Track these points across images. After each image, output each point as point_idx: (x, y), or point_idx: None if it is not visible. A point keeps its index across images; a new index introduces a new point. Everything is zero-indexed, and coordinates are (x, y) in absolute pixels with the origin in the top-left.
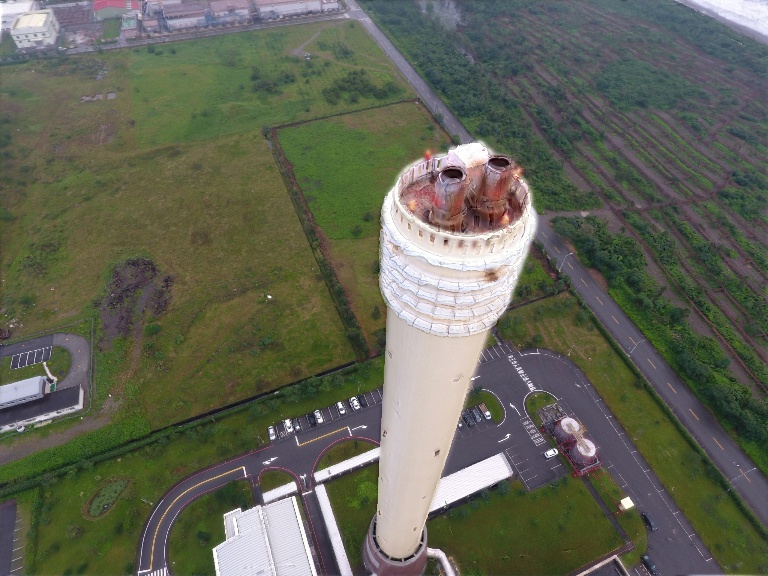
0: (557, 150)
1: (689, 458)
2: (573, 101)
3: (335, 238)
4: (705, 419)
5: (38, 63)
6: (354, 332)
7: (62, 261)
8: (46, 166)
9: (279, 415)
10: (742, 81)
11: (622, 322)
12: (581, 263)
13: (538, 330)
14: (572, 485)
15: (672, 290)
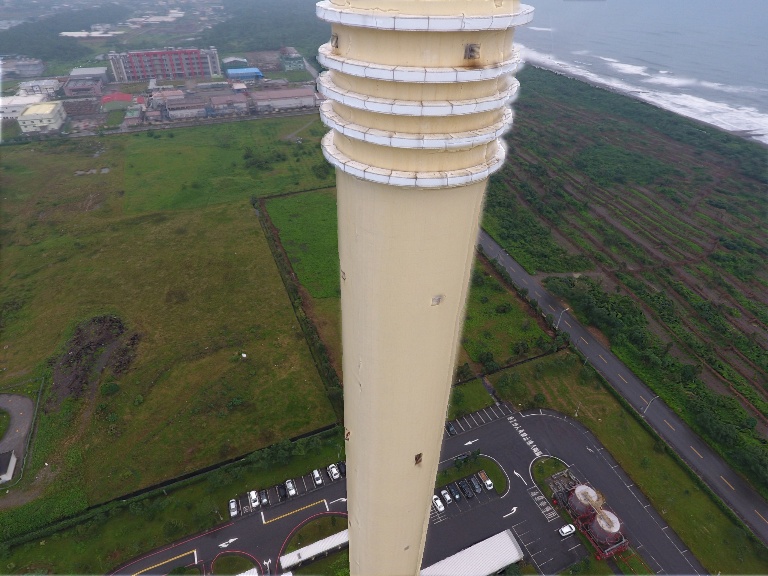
0: (543, 218)
1: (731, 535)
2: (554, 177)
3: (319, 297)
4: (741, 488)
5: (39, 144)
6: (335, 390)
7: (23, 319)
8: (26, 230)
9: (244, 486)
10: (712, 162)
11: (630, 380)
12: (578, 321)
13: (539, 389)
14: (596, 570)
15: (678, 348)
